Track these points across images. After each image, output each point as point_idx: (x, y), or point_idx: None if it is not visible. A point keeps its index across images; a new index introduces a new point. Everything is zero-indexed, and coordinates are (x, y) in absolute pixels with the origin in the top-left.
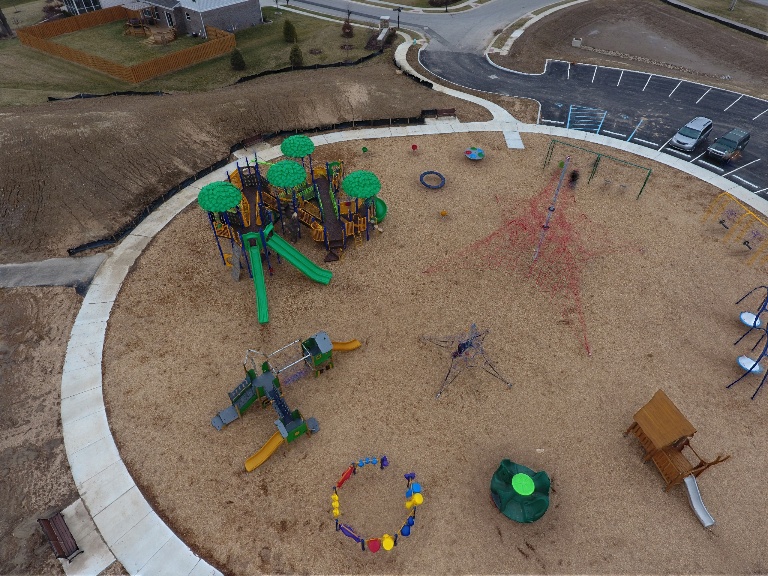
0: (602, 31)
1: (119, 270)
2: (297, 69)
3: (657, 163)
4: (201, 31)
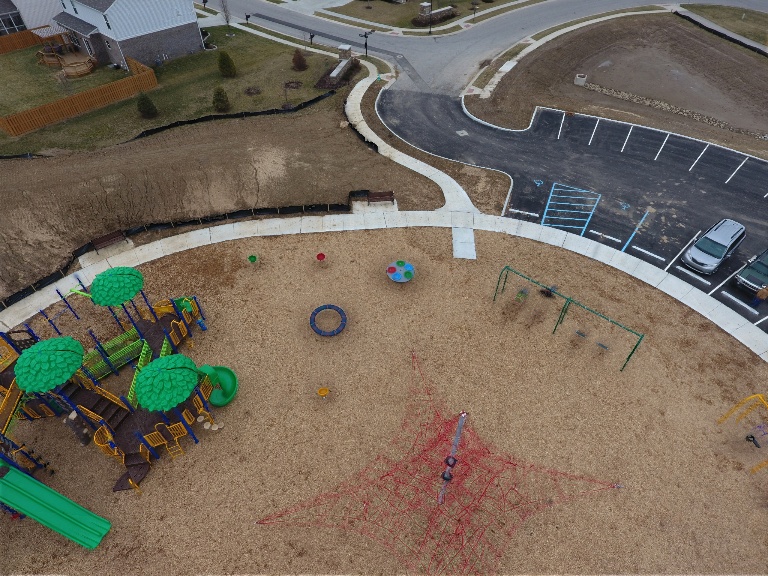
0: (615, 62)
1: None
2: (219, 118)
3: (660, 295)
4: (122, 62)
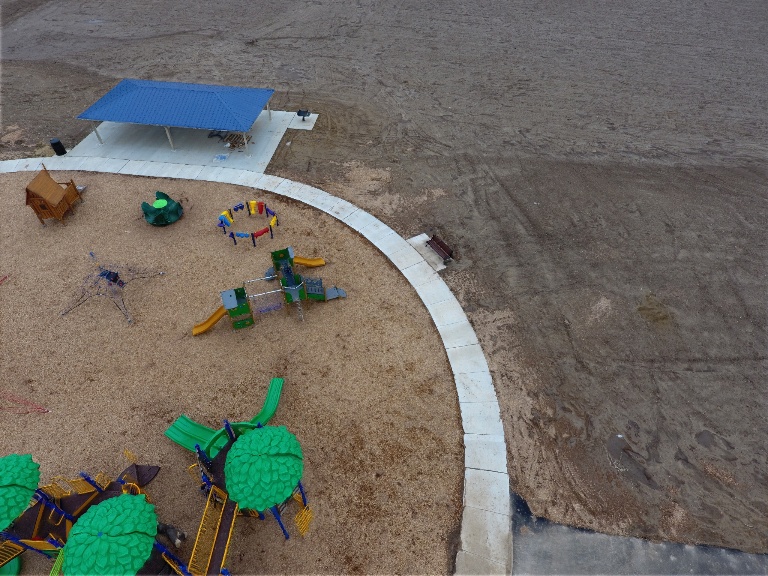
0: None
1: (476, 543)
2: None
3: None
4: None
